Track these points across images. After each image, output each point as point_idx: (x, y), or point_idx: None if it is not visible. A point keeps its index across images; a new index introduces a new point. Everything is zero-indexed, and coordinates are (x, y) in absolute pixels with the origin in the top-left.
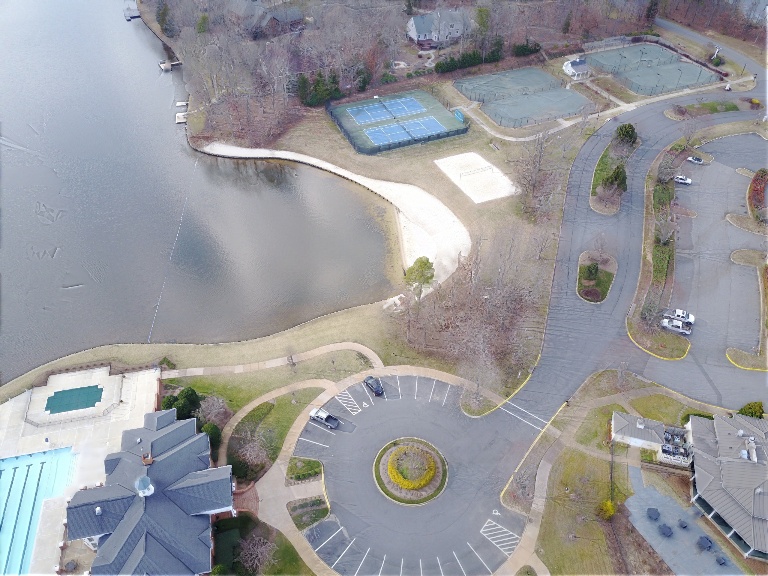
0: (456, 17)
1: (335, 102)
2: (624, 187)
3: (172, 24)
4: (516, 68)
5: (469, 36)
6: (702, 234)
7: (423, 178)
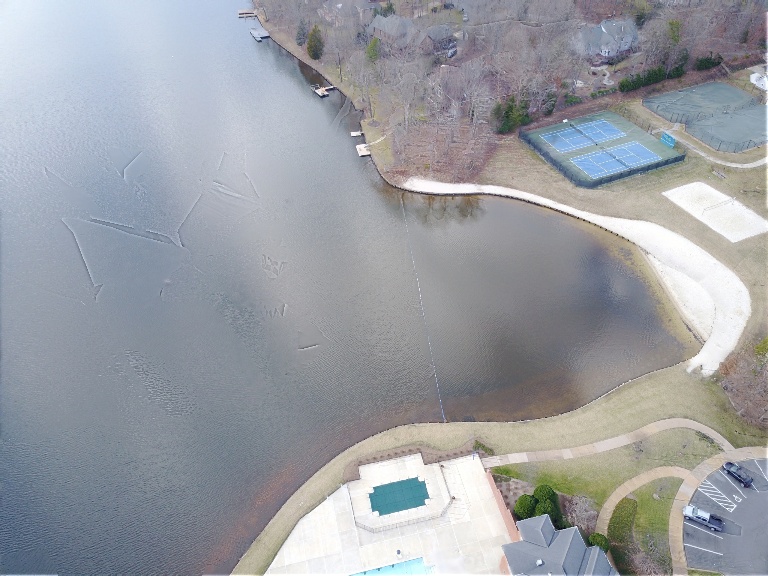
0: (625, 29)
1: (524, 128)
2: None
3: (330, 47)
4: (700, 83)
5: (637, 49)
6: None
7: (658, 213)
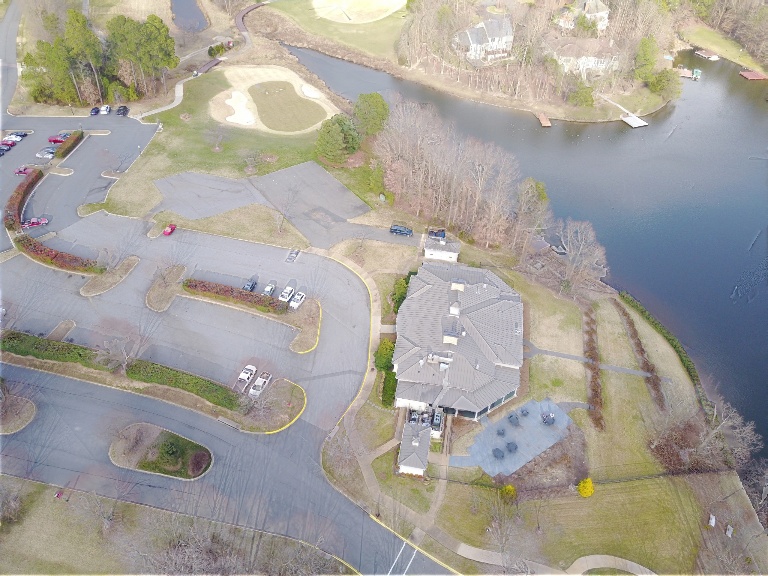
0: None
1: None
2: (1, 380)
3: None
4: None
5: None
6: (109, 325)
7: None
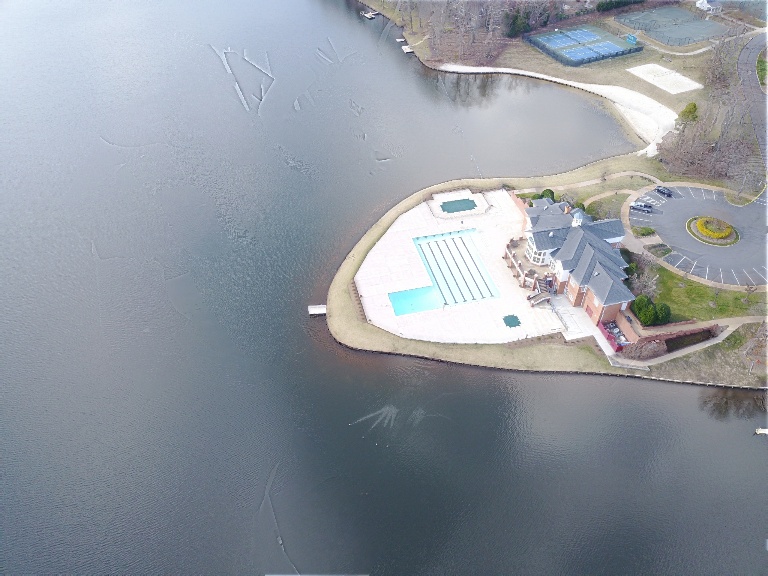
0: None
1: (526, 34)
2: None
3: None
4: (658, 7)
5: None
6: None
7: (623, 81)
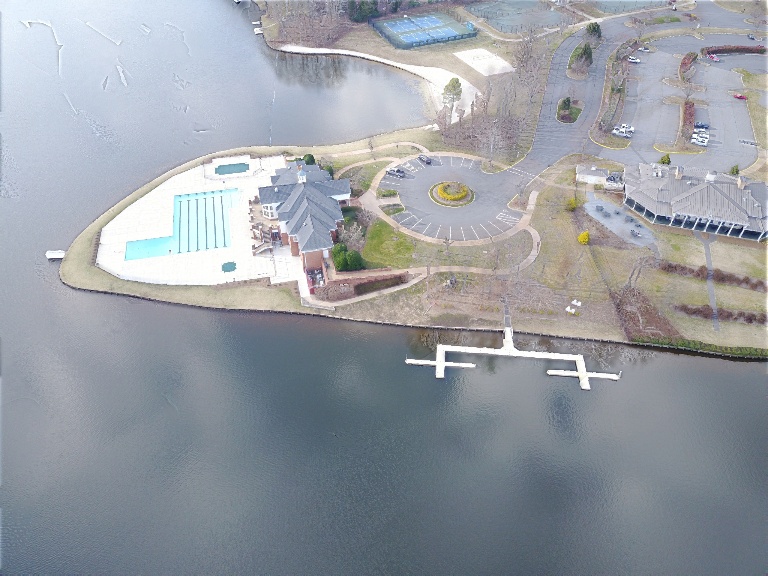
0: None
1: (375, 19)
2: (590, 60)
3: None
4: None
5: None
6: (645, 89)
7: (446, 63)
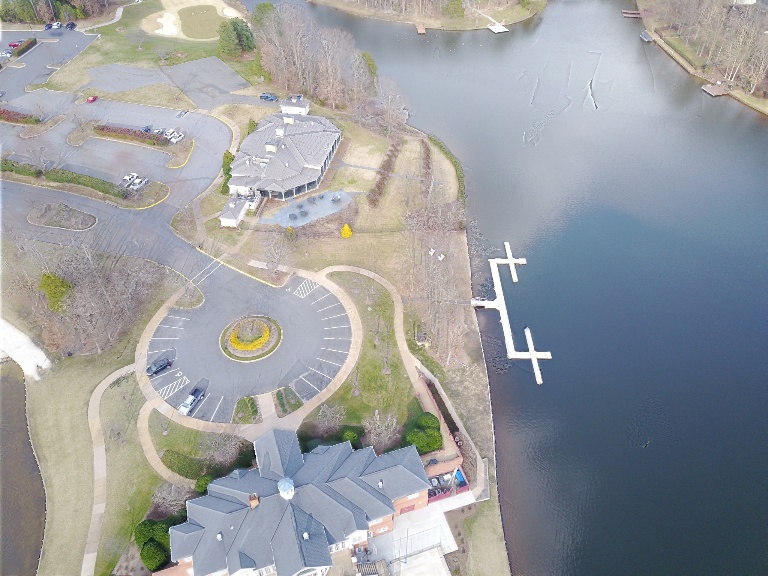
0: None
1: None
2: None
3: None
4: None
5: None
6: None
7: None
